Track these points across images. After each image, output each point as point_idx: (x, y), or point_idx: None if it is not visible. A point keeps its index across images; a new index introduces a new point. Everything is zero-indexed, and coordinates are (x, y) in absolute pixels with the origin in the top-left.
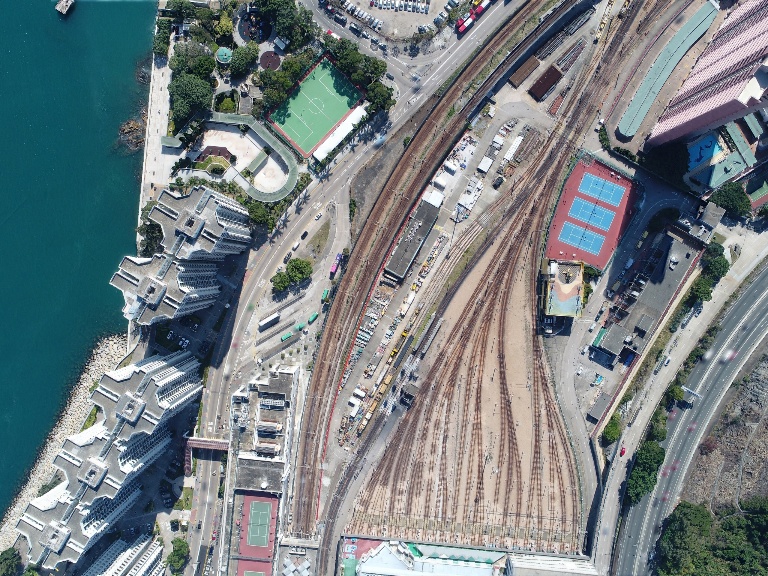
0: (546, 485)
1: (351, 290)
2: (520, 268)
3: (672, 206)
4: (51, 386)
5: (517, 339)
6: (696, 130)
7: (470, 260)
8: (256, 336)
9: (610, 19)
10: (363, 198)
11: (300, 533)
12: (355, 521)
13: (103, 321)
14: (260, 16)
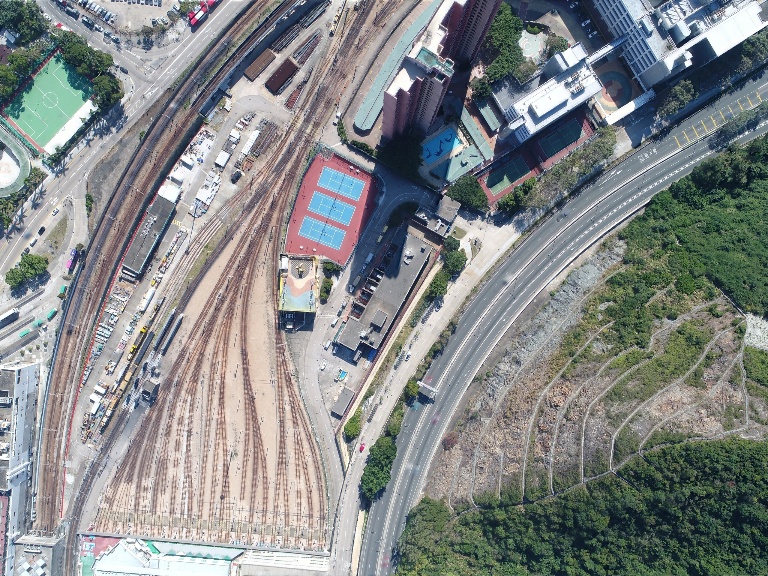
0: (292, 481)
1: (90, 286)
2: (261, 263)
3: (412, 200)
4: None
5: (259, 335)
6: (423, 123)
7: (210, 255)
8: None
9: (346, 11)
10: (100, 193)
11: (40, 531)
12: (100, 519)
13: None
14: None
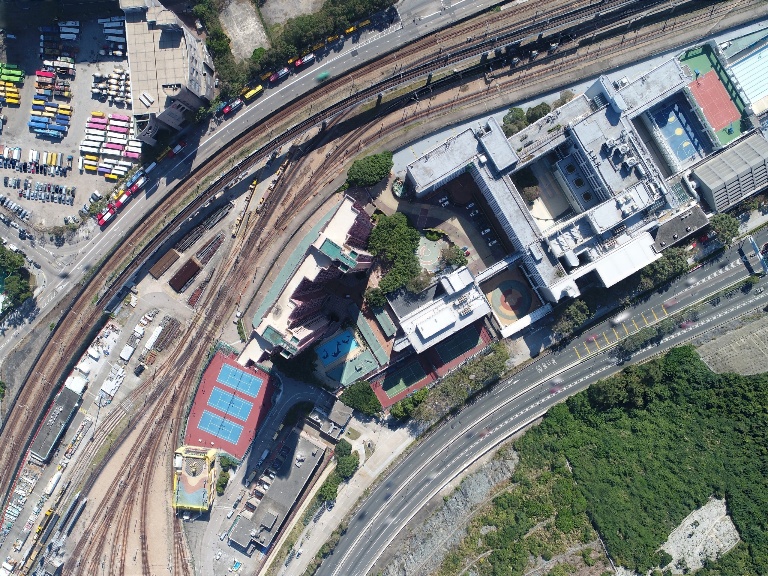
0: None
1: (1, 467)
2: (161, 453)
3: (308, 400)
4: None
5: (159, 522)
6: None
7: (113, 443)
8: None
9: (248, 214)
10: (13, 380)
11: None
12: None
13: None
14: None
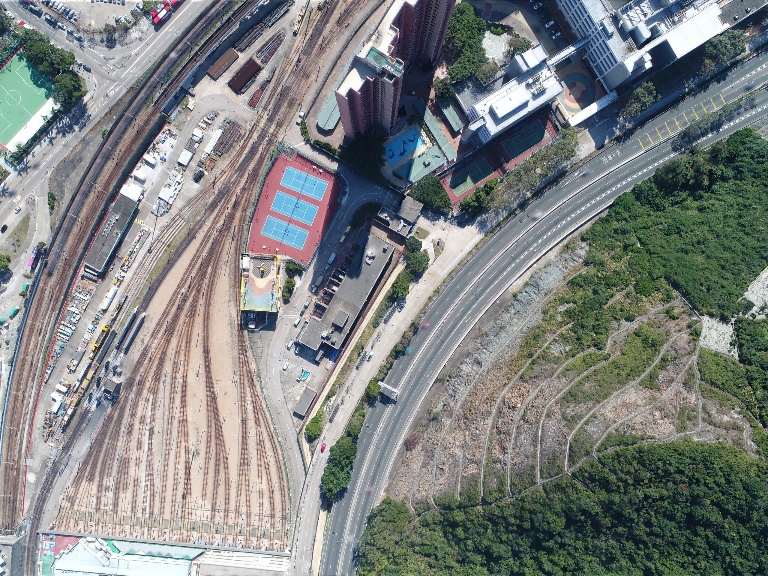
0: (254, 481)
1: (52, 284)
2: (223, 262)
3: (375, 200)
4: None
5: (222, 334)
6: (384, 123)
7: (172, 254)
8: None
9: (309, 11)
10: (63, 191)
11: (1, 529)
12: (61, 517)
13: None
14: None
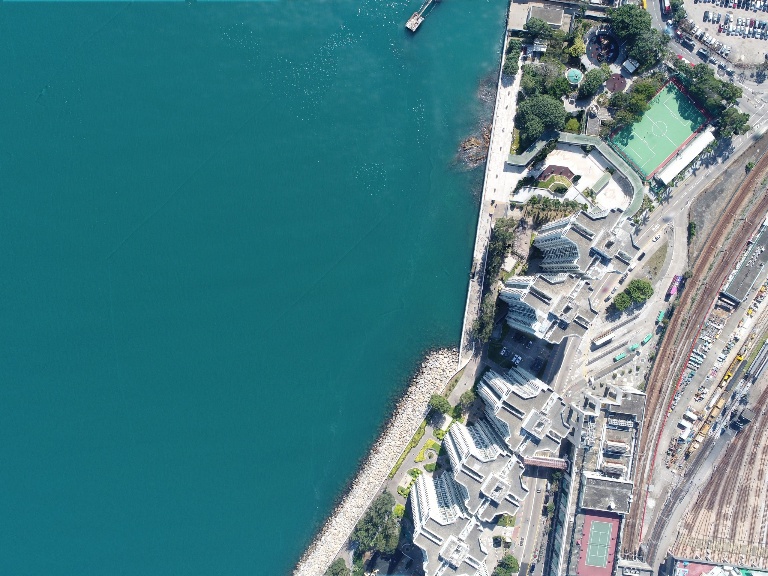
0: None
1: (686, 312)
2: None
3: None
4: (375, 397)
5: None
6: None
7: None
8: (588, 355)
9: None
10: (702, 221)
11: (628, 554)
12: (678, 544)
13: (431, 335)
14: (609, 39)
